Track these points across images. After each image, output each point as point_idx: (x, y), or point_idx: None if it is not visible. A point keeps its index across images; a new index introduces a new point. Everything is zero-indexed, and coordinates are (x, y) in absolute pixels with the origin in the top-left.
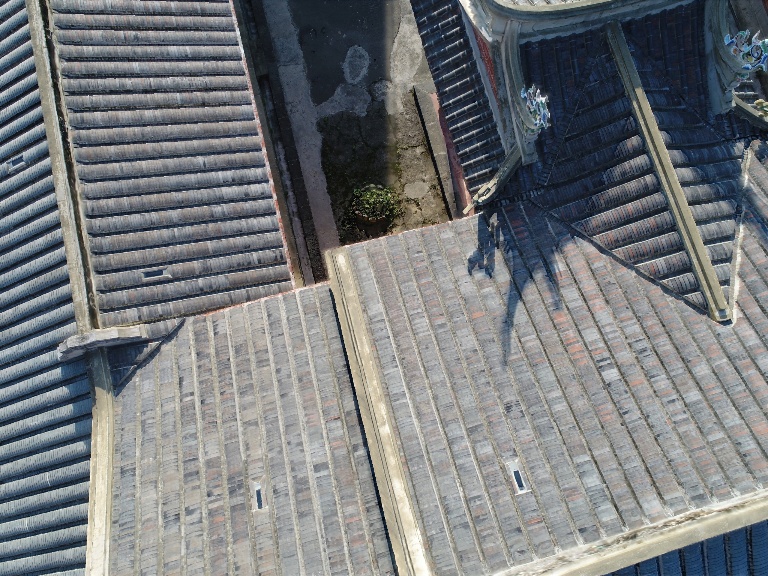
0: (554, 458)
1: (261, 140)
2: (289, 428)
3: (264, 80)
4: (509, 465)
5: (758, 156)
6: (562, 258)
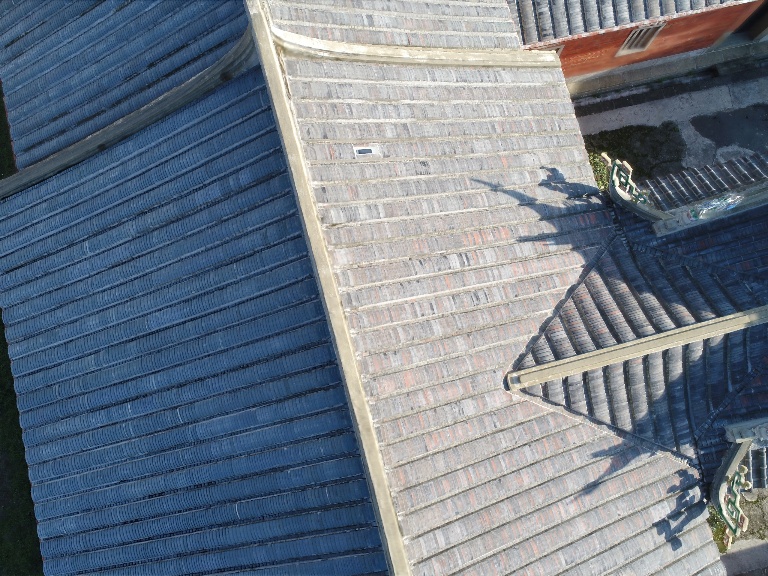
0: (382, 187)
1: (656, 19)
2: (401, 3)
3: (712, 75)
4: (377, 147)
5: (681, 472)
6: (561, 252)
